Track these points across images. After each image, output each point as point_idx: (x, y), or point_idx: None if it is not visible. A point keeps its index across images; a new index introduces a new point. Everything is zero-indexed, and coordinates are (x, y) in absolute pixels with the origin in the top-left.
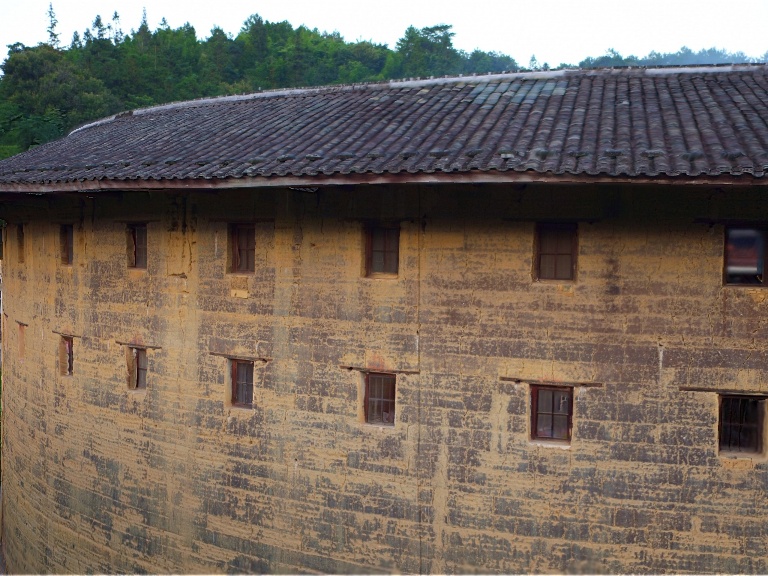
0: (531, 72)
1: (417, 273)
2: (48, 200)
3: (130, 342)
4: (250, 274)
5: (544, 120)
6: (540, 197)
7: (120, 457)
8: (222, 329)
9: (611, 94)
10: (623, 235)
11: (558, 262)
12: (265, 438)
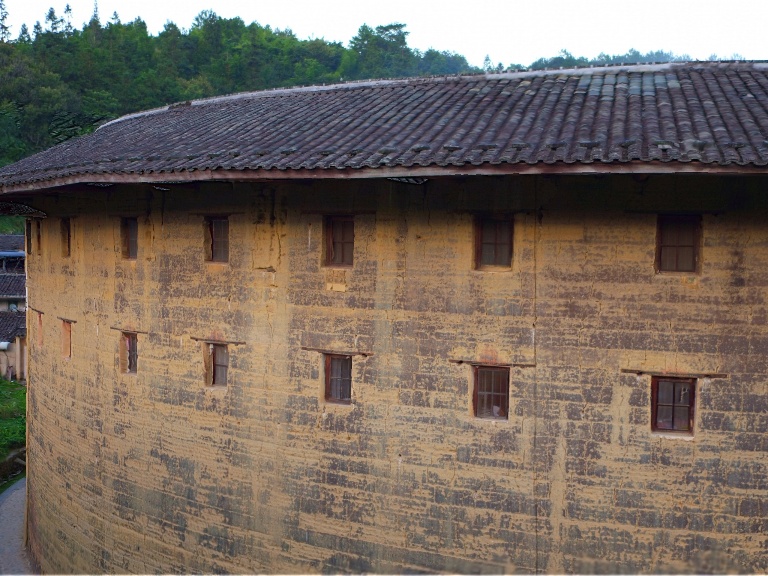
0: (636, 65)
1: (533, 265)
2: (108, 192)
3: (208, 338)
4: (347, 267)
5: (679, 112)
6: (663, 189)
7: (196, 456)
8: (316, 323)
9: (729, 87)
10: (748, 227)
11: (680, 254)
12: (365, 434)
